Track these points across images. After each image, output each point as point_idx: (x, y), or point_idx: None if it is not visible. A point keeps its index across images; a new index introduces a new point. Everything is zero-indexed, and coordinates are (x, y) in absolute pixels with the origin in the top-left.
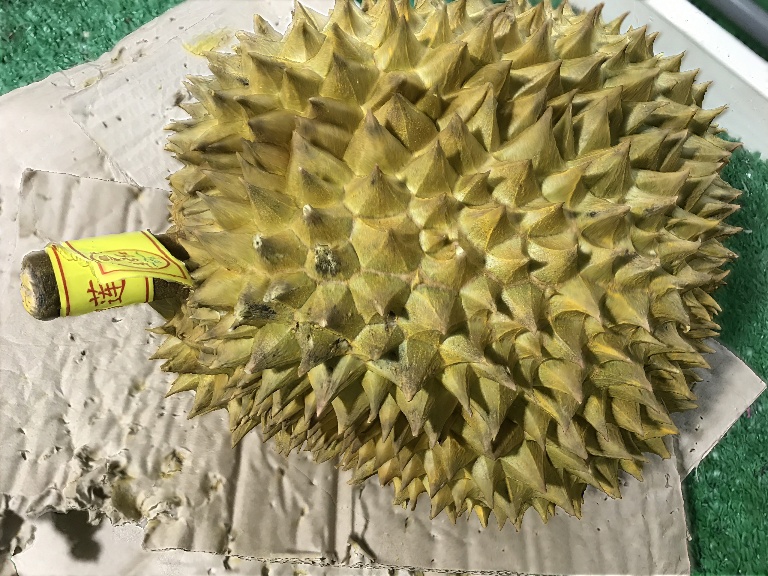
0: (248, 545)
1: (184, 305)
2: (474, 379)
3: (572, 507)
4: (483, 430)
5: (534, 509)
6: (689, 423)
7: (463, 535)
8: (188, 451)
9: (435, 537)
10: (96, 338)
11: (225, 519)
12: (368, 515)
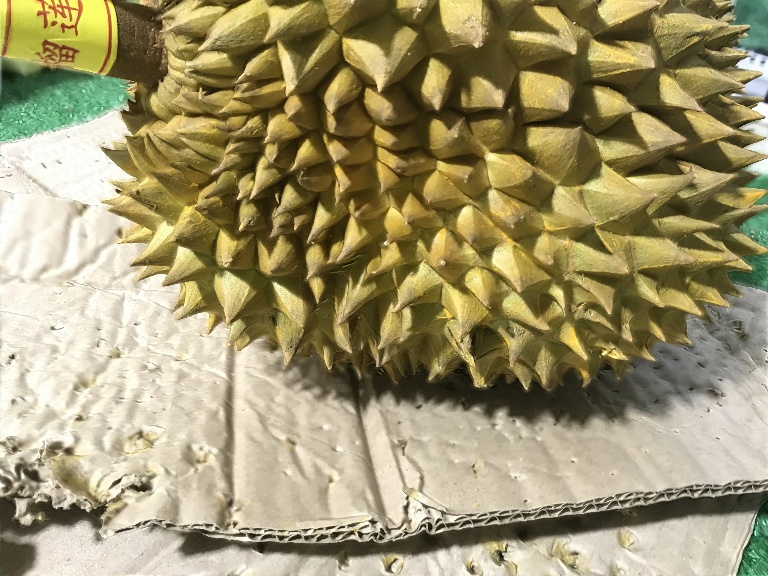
0: (261, 514)
1: (154, 93)
2: (528, 1)
3: (689, 254)
4: (555, 93)
5: (629, 430)
6: (755, 357)
7: (553, 469)
8: (160, 428)
9: (518, 478)
10: (30, 344)
11: (223, 489)
12: (421, 469)
